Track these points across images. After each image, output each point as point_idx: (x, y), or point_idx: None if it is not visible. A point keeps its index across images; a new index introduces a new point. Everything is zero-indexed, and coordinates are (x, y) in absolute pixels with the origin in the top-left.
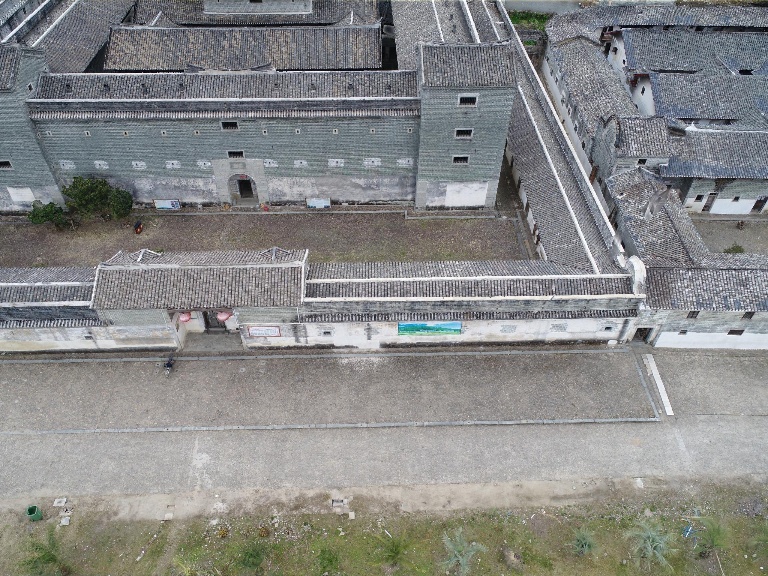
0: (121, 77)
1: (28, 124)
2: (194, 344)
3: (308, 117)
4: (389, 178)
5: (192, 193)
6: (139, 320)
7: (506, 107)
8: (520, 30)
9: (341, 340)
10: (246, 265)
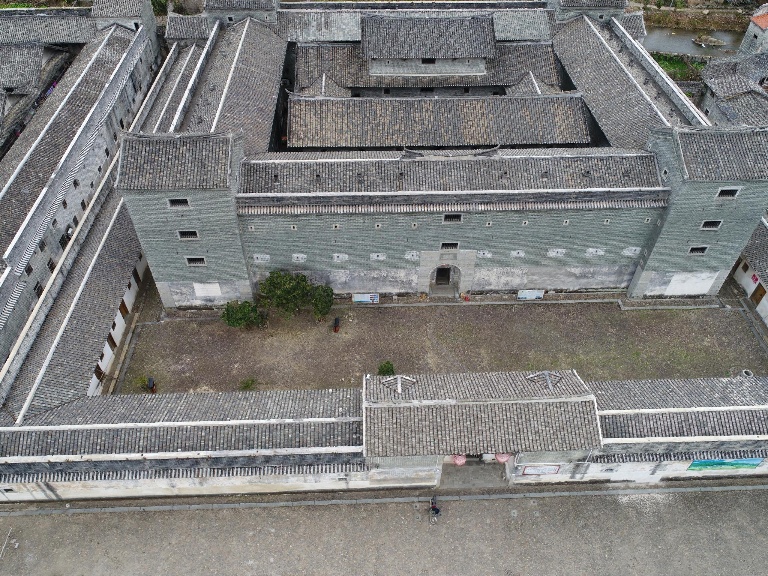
0: (330, 164)
1: (236, 221)
2: (449, 479)
3: (542, 209)
4: (608, 267)
5: (389, 284)
6: (408, 463)
7: (767, 199)
8: (679, 82)
9: (621, 475)
10: (531, 400)
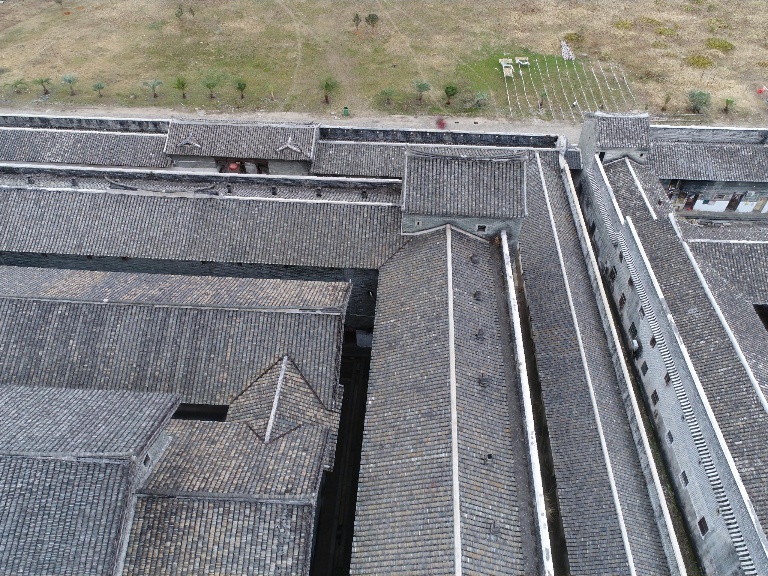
0: None
1: None
2: None
3: None
4: None
5: None
6: None
7: None
8: None
9: None
10: None
